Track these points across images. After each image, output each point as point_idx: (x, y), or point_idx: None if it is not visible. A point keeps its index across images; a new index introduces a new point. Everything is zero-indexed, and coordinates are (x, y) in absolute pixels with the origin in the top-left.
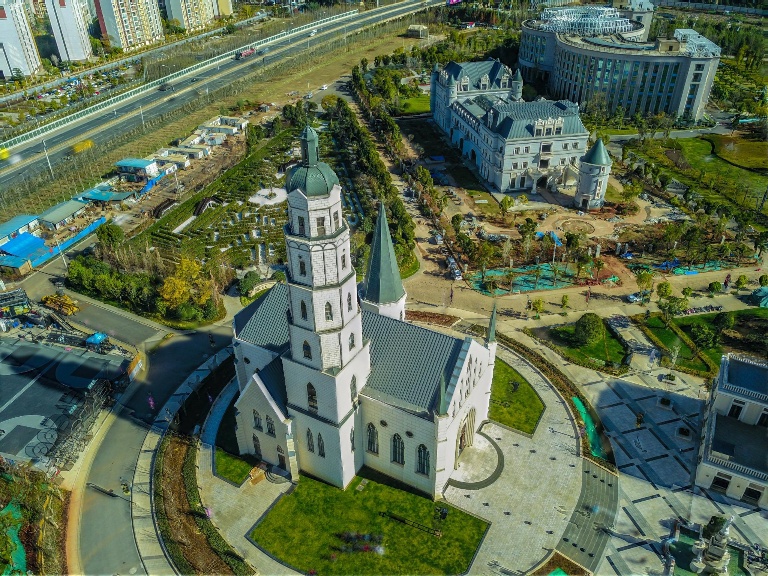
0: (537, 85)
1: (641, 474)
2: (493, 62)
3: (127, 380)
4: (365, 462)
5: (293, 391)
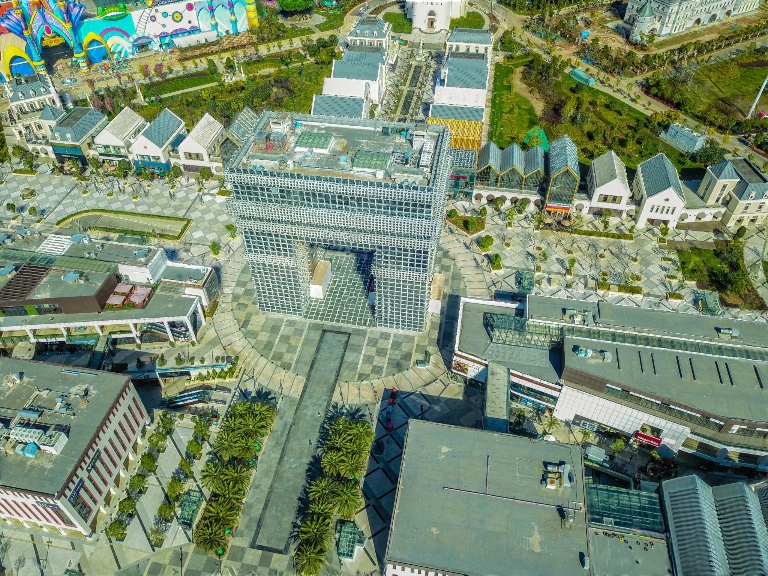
0: None
1: None
2: None
3: None
4: None
5: None
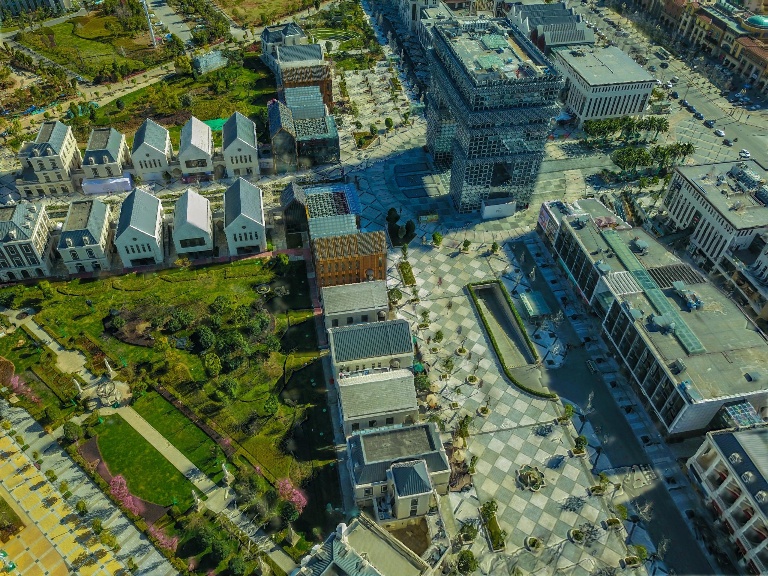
0: None
1: None
2: None
3: None
4: None
5: None
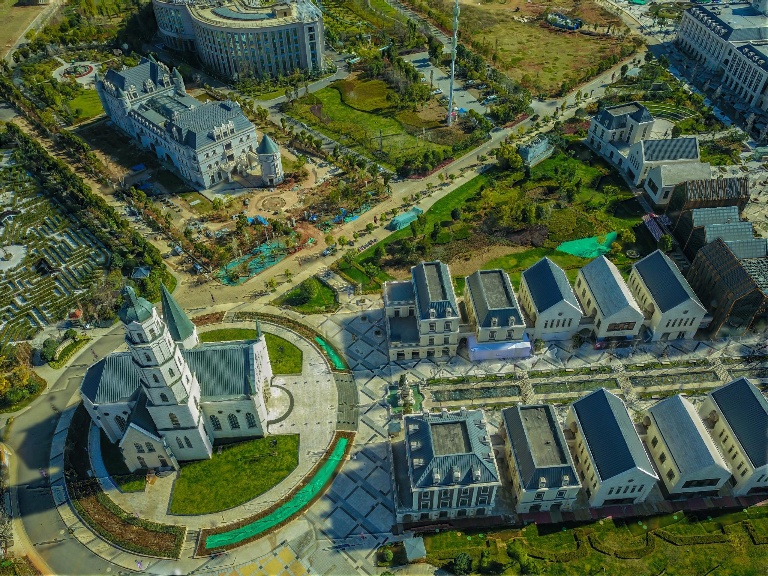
0: (188, 57)
1: (364, 368)
2: (149, 63)
3: (5, 468)
4: (215, 437)
5: (160, 421)
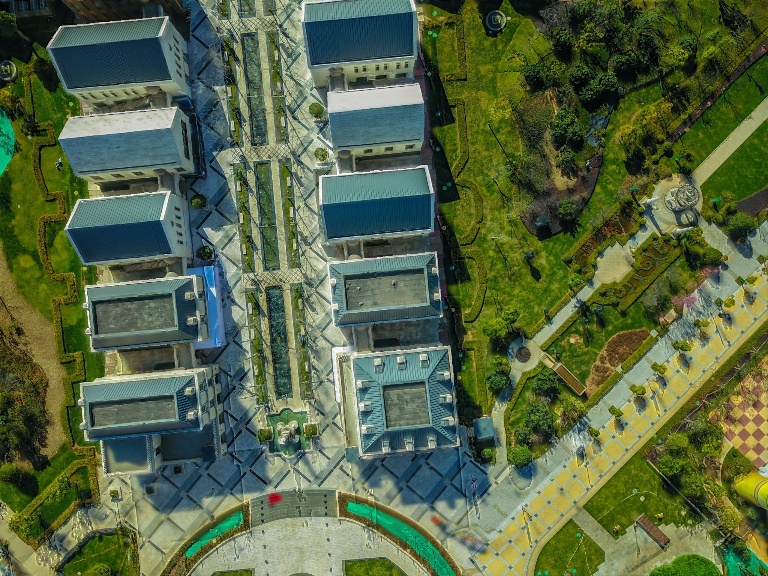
0: None
1: (238, 486)
2: None
3: None
4: None
5: None
